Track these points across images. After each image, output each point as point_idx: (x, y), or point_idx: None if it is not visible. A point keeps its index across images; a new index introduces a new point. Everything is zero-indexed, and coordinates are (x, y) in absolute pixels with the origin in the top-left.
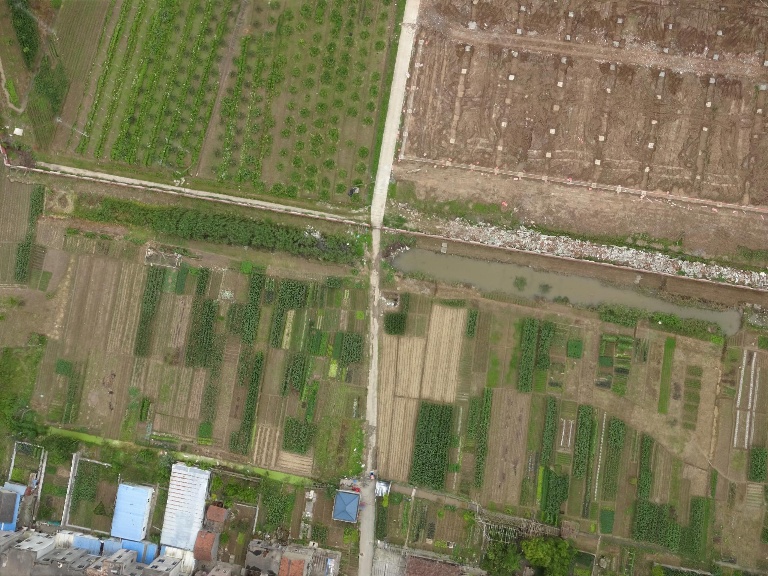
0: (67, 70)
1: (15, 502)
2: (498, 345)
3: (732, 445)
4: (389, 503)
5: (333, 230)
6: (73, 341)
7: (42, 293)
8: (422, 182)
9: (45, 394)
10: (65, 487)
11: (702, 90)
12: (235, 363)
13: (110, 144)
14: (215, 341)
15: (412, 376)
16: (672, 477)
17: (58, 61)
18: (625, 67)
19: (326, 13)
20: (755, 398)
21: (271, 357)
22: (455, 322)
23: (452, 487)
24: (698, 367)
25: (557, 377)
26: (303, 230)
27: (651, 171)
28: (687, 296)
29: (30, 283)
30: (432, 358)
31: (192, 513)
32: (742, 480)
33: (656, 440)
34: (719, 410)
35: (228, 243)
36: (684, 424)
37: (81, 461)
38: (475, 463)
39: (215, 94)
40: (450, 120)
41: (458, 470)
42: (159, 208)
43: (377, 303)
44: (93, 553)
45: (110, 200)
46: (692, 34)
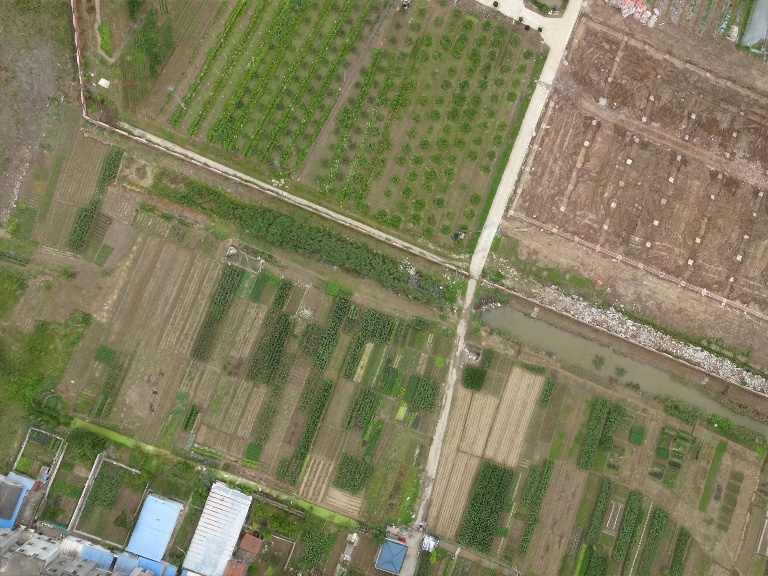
0: (175, 31)
1: (19, 497)
2: (567, 418)
3: (756, 551)
4: None
5: (430, 270)
6: (122, 328)
7: (98, 268)
8: (526, 242)
9: (77, 380)
10: (80, 488)
11: None
12: (300, 386)
13: (209, 123)
14: (283, 359)
15: (479, 434)
16: (699, 573)
17: (167, 18)
18: (732, 179)
19: (465, 49)
20: None
21: (340, 387)
22: (531, 388)
23: (497, 551)
24: (741, 473)
25: (616, 460)
26: (399, 263)
27: (735, 282)
28: (744, 405)
29: (86, 254)
30: (502, 419)
31: (225, 539)
32: None
33: (692, 535)
34: (751, 516)
35: (318, 259)
36: (719, 524)
37: (106, 462)
38: (524, 531)
39: (335, 100)
40: (565, 188)
41: (506, 535)
42: (251, 205)
43: (459, 354)
44: (102, 567)
45: (197, 184)
46: None
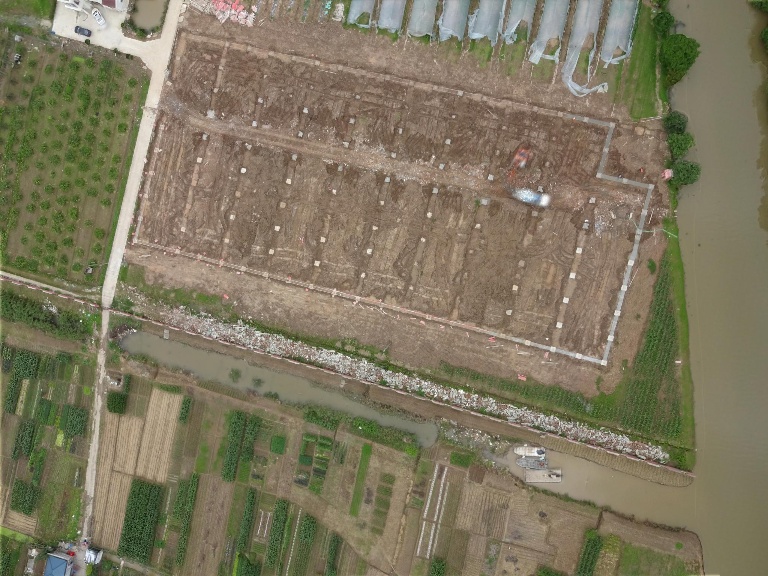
0: None
1: None
2: (209, 433)
3: (415, 553)
4: (100, 569)
5: (68, 306)
6: None
7: None
8: (152, 267)
9: None
10: None
11: (423, 200)
12: None
13: None
14: None
15: (129, 453)
16: None
17: None
18: (351, 170)
19: (76, 90)
20: (442, 511)
21: (6, 421)
22: (171, 407)
23: (157, 561)
24: (391, 475)
25: (259, 470)
26: (41, 304)
27: (366, 277)
28: (388, 405)
29: None
30: (148, 439)
31: None
32: None
33: (345, 540)
34: (406, 519)
35: None
36: (372, 528)
37: None
38: (178, 542)
39: None
40: (182, 208)
41: (162, 546)
42: None
43: (102, 381)
44: None
45: None
46: (420, 141)
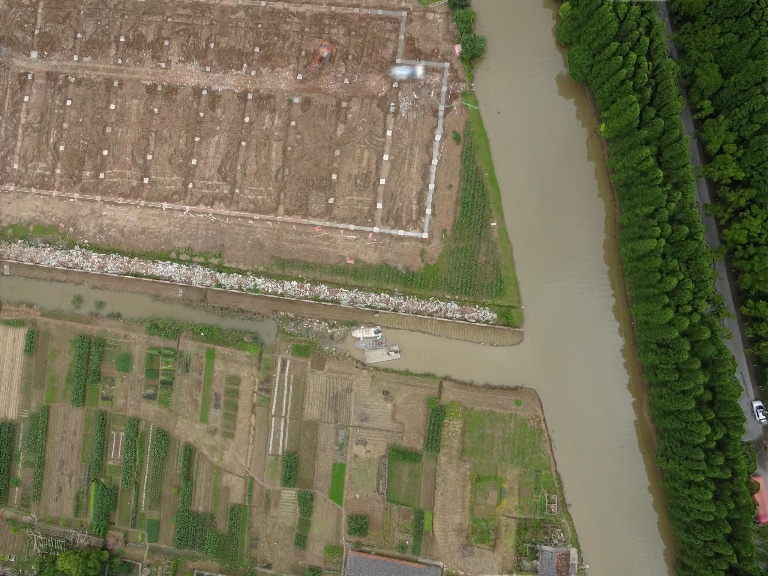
0: None
1: None
2: (55, 362)
3: (268, 452)
4: None
5: None
6: None
7: None
8: None
9: None
10: None
11: (239, 106)
12: None
13: None
14: None
15: None
16: (212, 485)
17: None
18: (169, 87)
19: None
20: (289, 405)
21: None
22: (17, 341)
23: (14, 501)
24: (236, 376)
25: (108, 391)
26: None
27: (193, 187)
28: (226, 307)
29: None
30: None
31: None
32: (277, 486)
33: (198, 449)
34: (256, 418)
35: None
36: (223, 433)
37: None
38: (33, 477)
39: None
40: (13, 146)
41: (18, 485)
42: None
43: None
44: None
45: None
46: (231, 52)
